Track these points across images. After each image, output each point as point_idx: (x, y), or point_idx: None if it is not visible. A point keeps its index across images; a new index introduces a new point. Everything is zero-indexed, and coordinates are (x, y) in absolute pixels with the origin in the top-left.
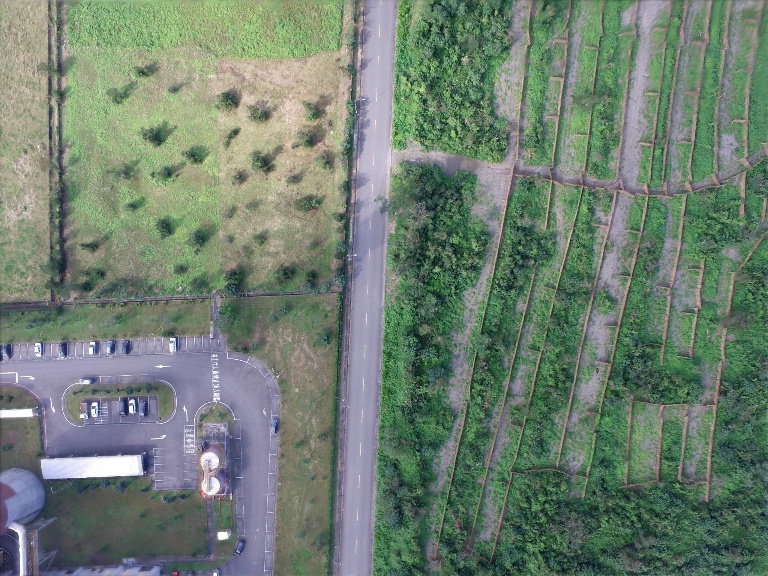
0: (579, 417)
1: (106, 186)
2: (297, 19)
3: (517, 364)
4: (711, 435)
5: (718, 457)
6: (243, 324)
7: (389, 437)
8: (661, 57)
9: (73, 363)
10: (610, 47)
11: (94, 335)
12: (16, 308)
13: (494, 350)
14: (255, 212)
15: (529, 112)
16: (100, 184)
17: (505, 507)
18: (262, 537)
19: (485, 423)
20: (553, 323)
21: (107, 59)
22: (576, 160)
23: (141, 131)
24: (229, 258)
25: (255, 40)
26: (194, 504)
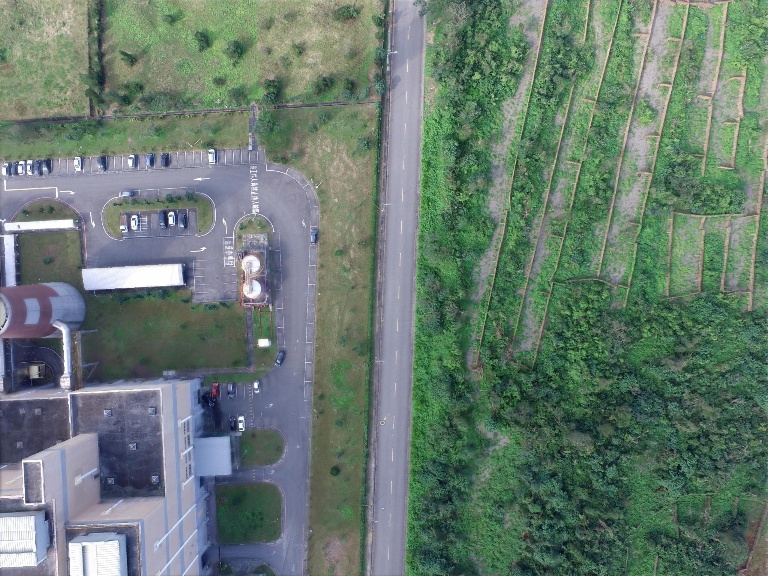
0: (620, 229)
1: (144, 0)
2: None
3: (557, 176)
4: (754, 246)
5: (762, 265)
6: (282, 135)
7: (430, 240)
8: None
9: (112, 177)
10: None
11: (133, 148)
12: None
13: (534, 160)
14: (293, 23)
15: None
16: None
17: (546, 317)
18: (302, 348)
19: (525, 231)
20: (593, 131)
21: None
22: None
23: None
24: (267, 70)
25: None
26: (234, 315)
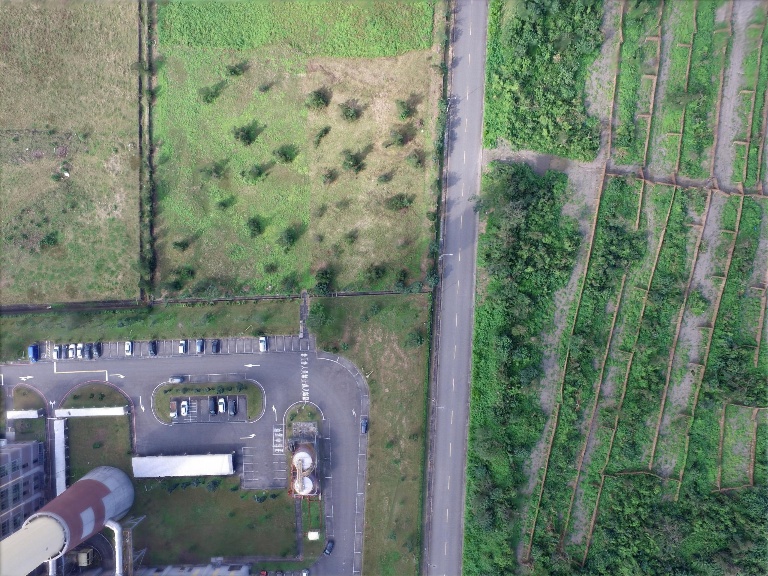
0: (671, 419)
1: (196, 185)
2: (388, 17)
3: (608, 365)
4: None
5: None
6: (333, 323)
7: (483, 438)
8: (757, 54)
9: (162, 362)
10: (704, 44)
11: (184, 334)
12: (106, 306)
13: (586, 351)
14: (345, 211)
15: (621, 110)
16: (190, 183)
17: (596, 510)
18: (351, 538)
19: (577, 425)
20: (646, 324)
21: (197, 58)
22: (668, 159)
23: (233, 130)
24: (319, 257)
25: (346, 39)
26: (283, 504)
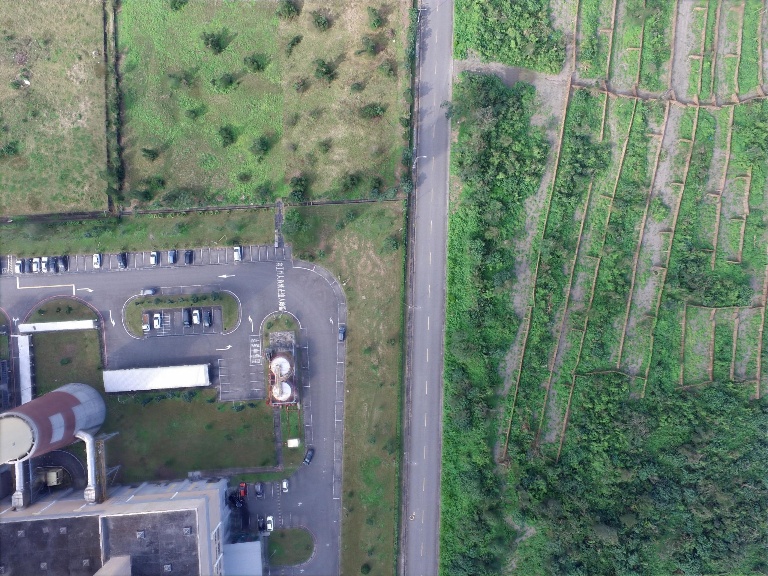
0: (636, 321)
1: (165, 94)
2: None
3: (577, 271)
4: (760, 336)
5: (767, 356)
6: (308, 232)
7: (459, 339)
8: None
9: (133, 274)
10: None
11: (155, 245)
12: (72, 219)
13: (556, 256)
14: (319, 120)
15: (584, 25)
16: (159, 91)
17: (569, 409)
18: (331, 445)
19: (549, 326)
20: (612, 228)
21: None
22: (629, 73)
23: (203, 35)
24: (293, 166)
25: None
26: (261, 414)
